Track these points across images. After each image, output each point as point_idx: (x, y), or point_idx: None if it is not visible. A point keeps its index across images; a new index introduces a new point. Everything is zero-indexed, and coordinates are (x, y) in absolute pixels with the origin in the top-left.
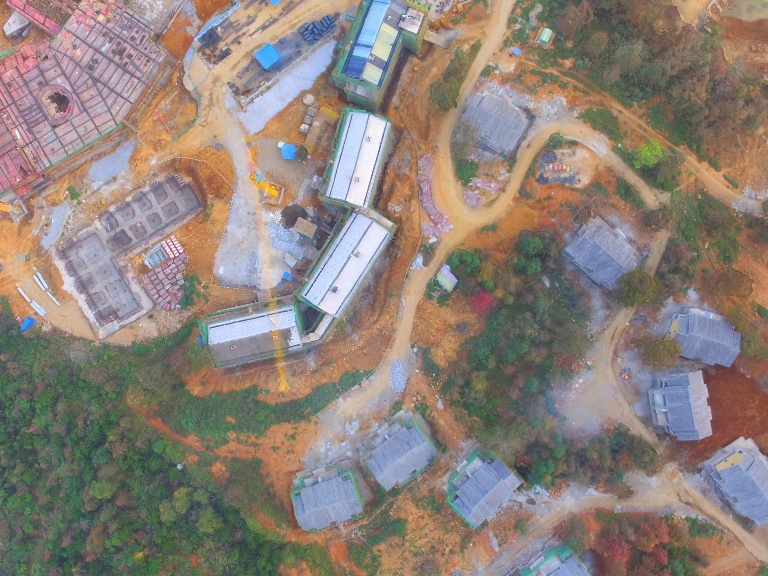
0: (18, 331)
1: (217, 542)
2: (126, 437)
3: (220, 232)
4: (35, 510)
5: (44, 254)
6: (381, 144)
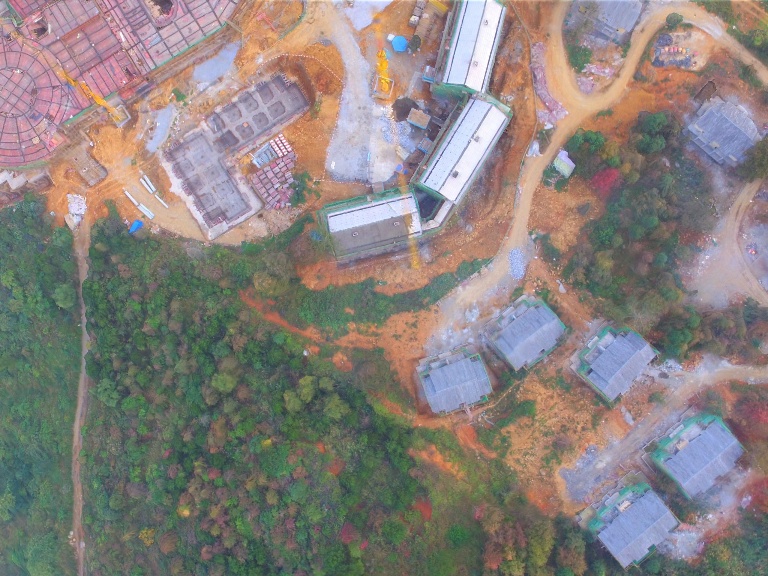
0: (128, 233)
1: (343, 429)
2: (244, 331)
3: (330, 127)
4: (150, 411)
5: (151, 157)
6: (497, 29)
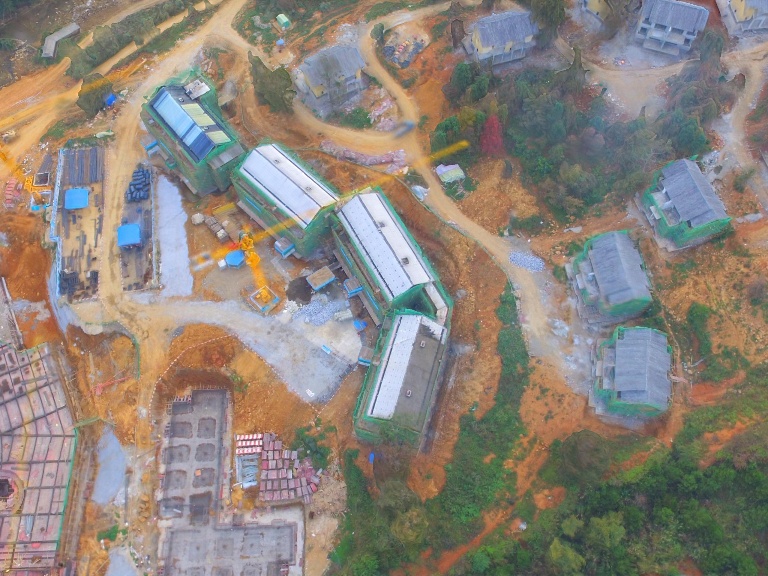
0: None
1: (640, 540)
2: None
3: (268, 374)
4: None
5: None
6: (288, 159)
